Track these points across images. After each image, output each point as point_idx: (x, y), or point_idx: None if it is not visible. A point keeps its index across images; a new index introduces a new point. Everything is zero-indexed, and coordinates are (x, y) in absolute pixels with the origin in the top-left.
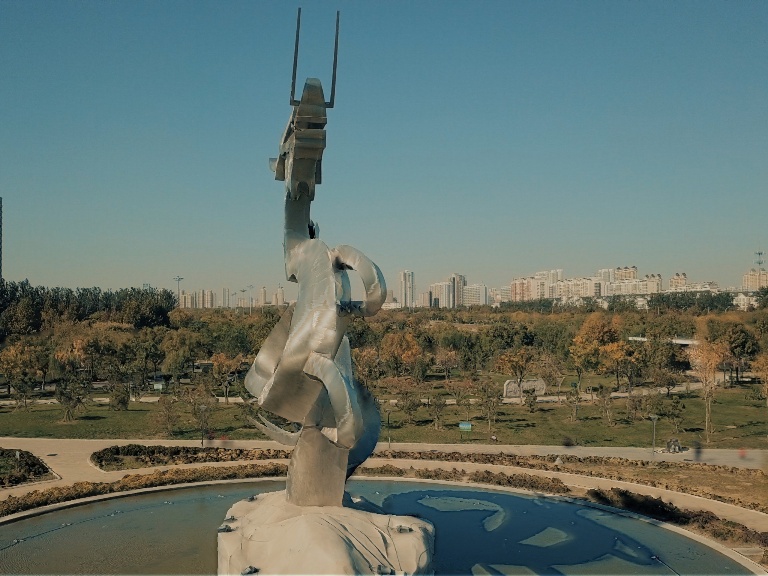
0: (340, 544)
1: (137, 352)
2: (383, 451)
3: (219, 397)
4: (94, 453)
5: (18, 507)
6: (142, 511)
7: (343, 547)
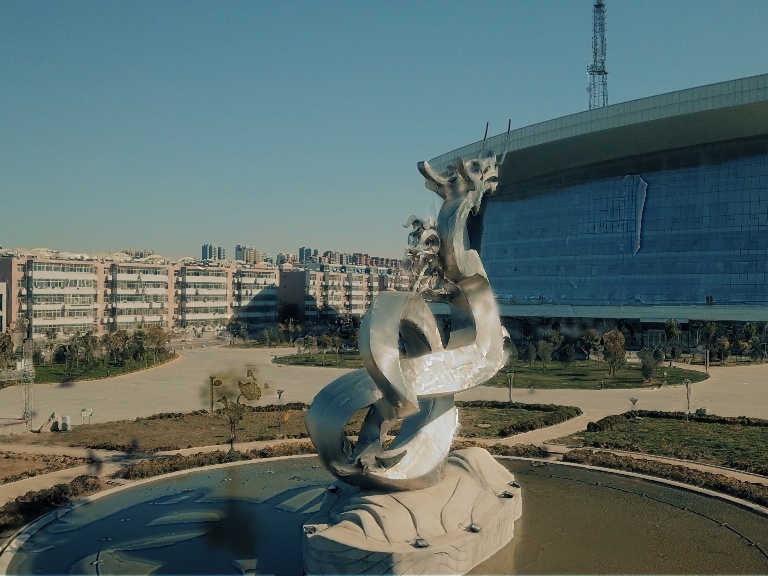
0: None
1: None
2: None
3: None
4: None
5: None
6: None
7: None
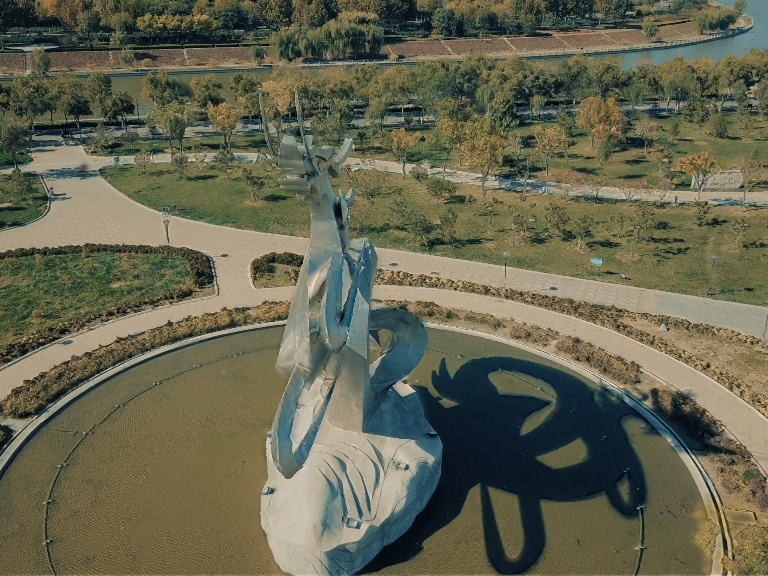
0: (322, 497)
1: None
2: (500, 288)
3: None
4: (254, 261)
5: (168, 340)
6: (259, 354)
7: (324, 501)
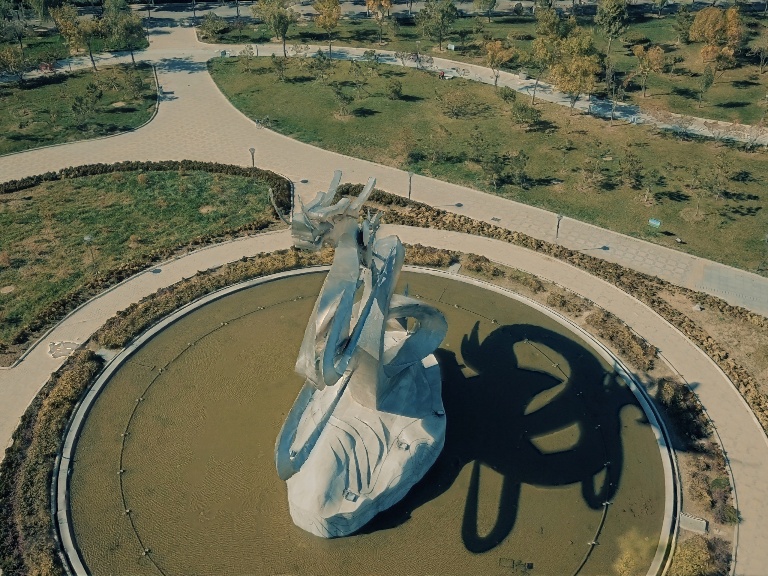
0: (329, 473)
1: (433, 14)
2: (552, 244)
3: (500, 71)
4: None
5: (240, 279)
6: None
7: (330, 476)
